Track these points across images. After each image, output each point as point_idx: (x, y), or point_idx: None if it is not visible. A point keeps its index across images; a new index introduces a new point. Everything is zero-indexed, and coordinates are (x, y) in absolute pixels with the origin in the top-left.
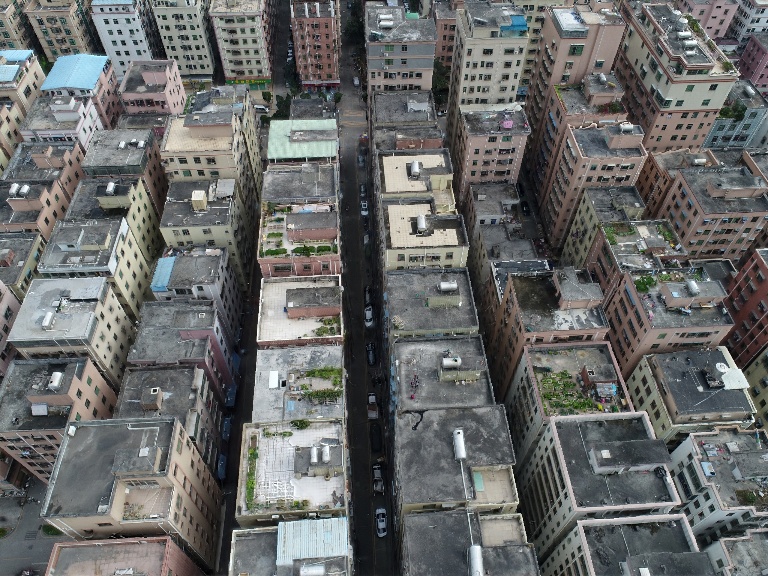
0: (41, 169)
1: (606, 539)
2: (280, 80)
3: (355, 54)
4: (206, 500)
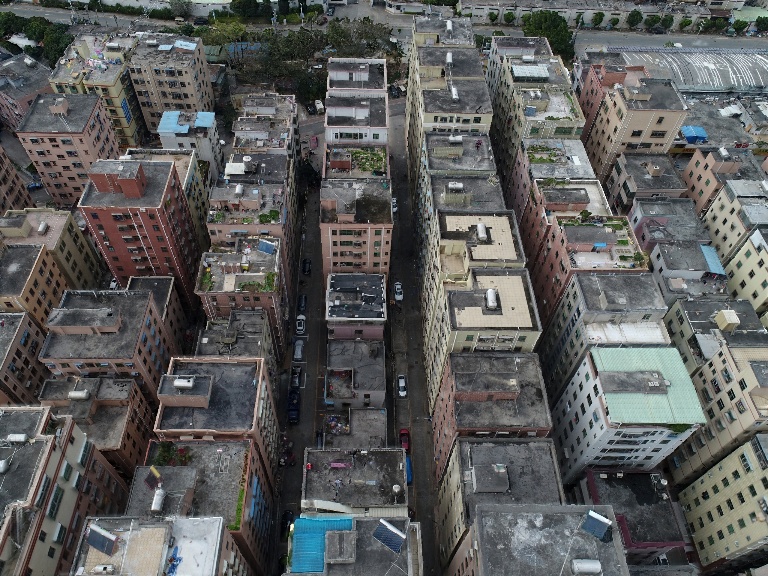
0: None
1: (372, 88)
2: None
3: None
4: (593, 165)
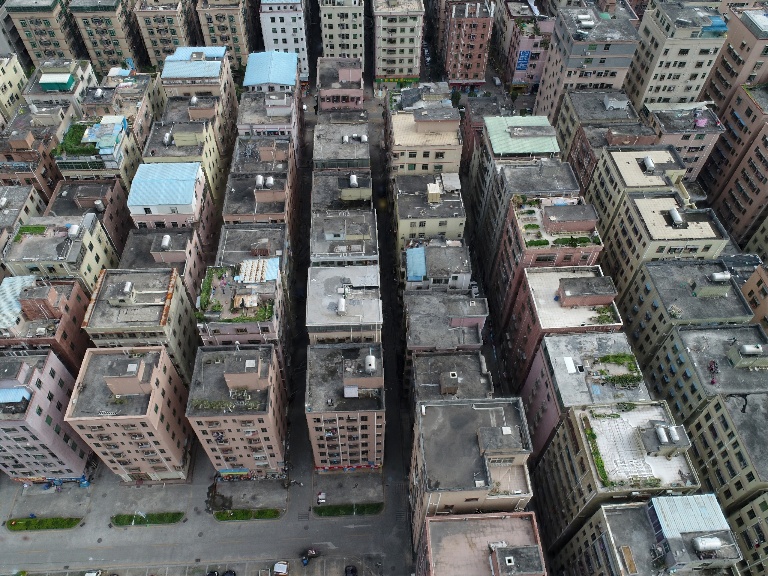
0: (264, 162)
1: None
2: (423, 79)
3: (488, 54)
4: None
